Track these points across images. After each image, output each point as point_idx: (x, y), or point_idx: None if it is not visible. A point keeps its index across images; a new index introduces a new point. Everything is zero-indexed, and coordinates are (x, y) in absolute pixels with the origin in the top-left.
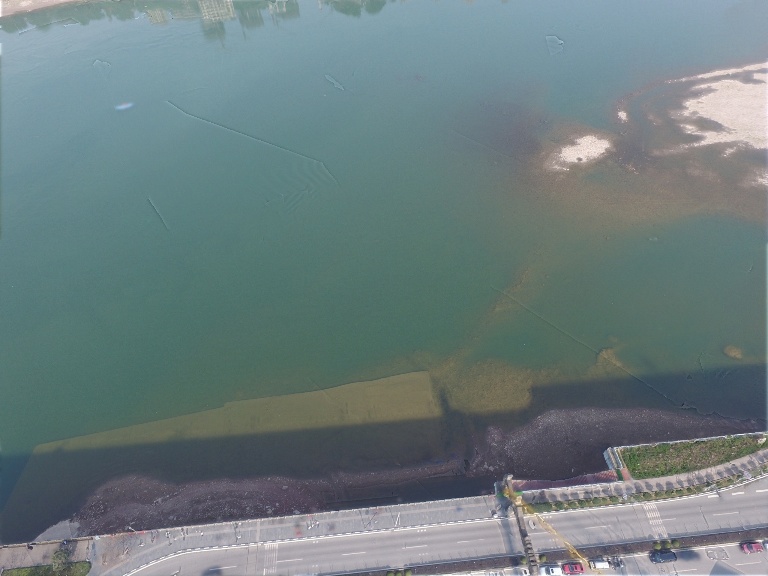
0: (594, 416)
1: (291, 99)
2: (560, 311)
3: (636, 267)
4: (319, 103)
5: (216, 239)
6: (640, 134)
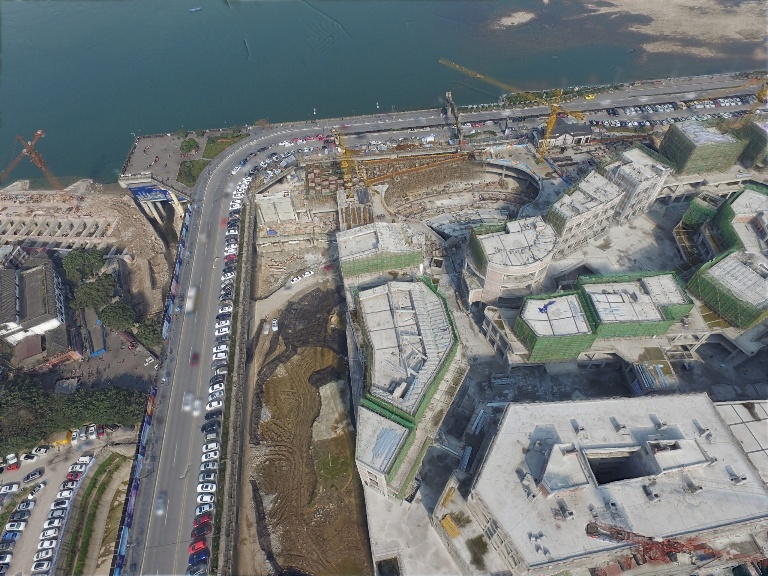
0: None
1: (312, 3)
2: (491, 88)
3: (542, 70)
4: (333, 3)
5: (277, 61)
6: (556, 10)
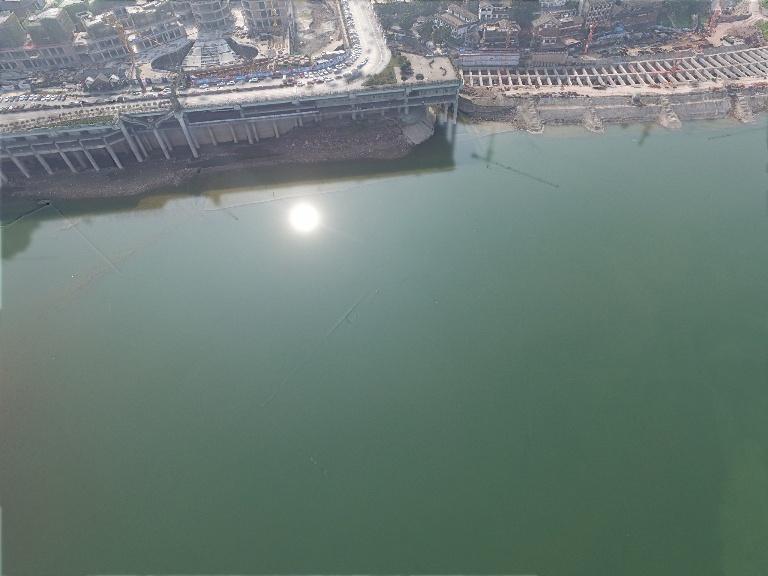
0: (109, 190)
1: None
2: (77, 255)
3: None
4: None
5: None
6: None
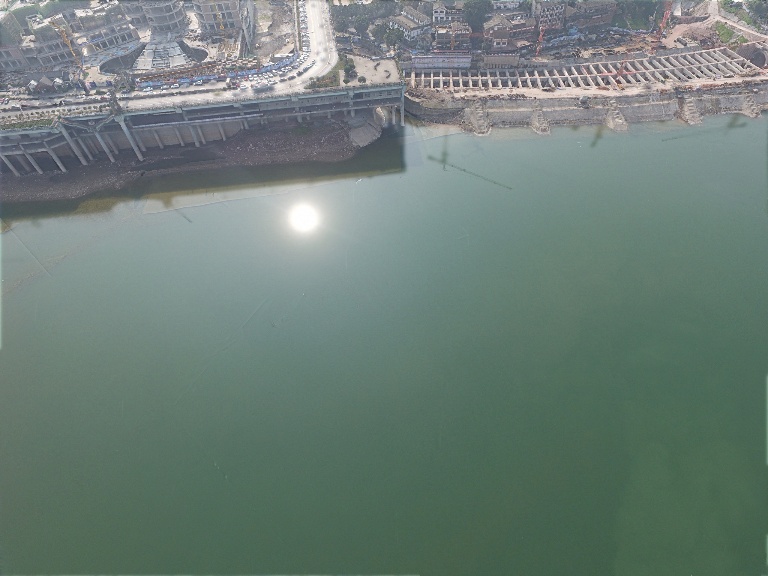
0: (49, 193)
1: None
2: (10, 259)
3: None
4: None
5: None
6: None
